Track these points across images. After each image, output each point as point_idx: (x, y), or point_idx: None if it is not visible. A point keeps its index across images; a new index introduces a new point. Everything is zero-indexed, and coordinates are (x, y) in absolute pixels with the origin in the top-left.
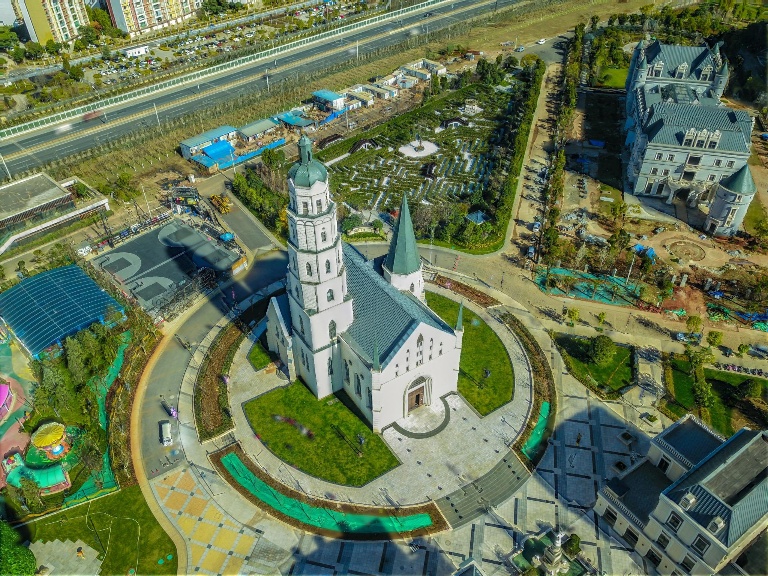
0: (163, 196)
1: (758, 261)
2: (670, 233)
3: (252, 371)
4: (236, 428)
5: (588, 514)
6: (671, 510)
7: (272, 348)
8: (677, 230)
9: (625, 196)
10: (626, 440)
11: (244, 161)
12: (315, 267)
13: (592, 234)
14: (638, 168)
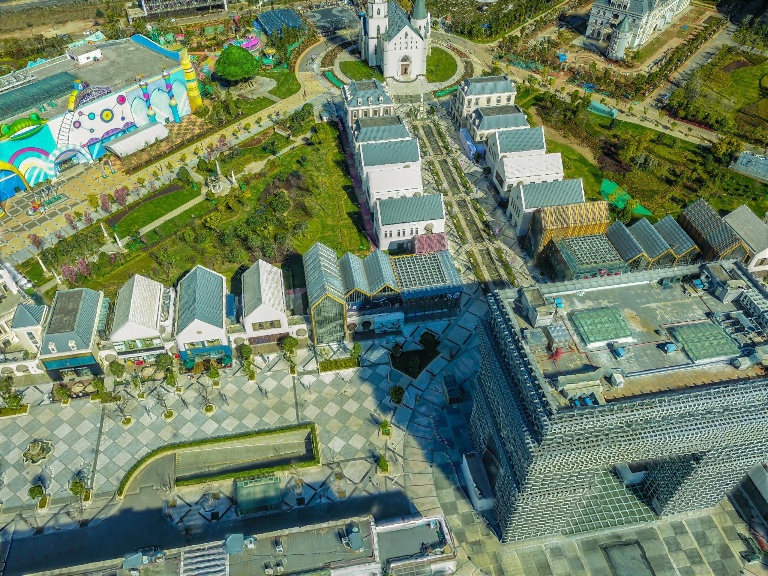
0: None
1: None
2: (586, 54)
3: (349, 55)
4: (334, 67)
5: (446, 111)
6: None
7: (360, 49)
8: (591, 53)
9: (580, 36)
10: None
11: None
12: None
13: None
14: None
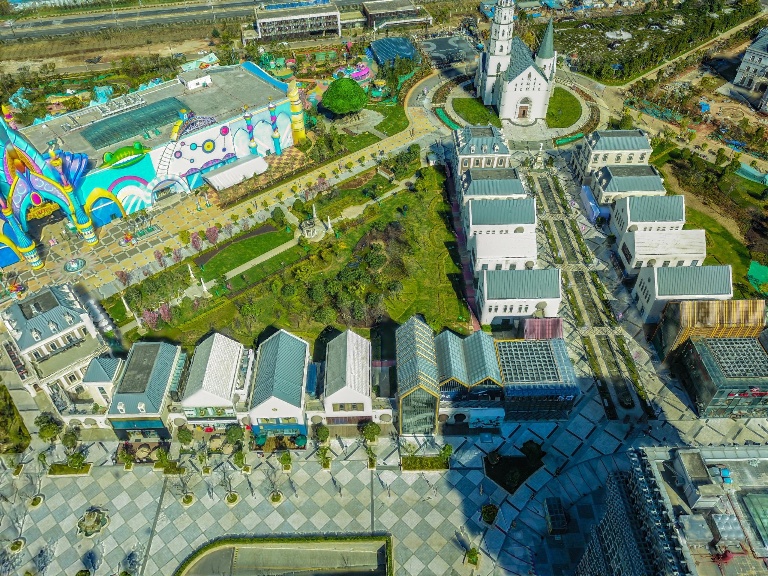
0: None
1: None
2: (733, 104)
3: (463, 91)
4: (446, 103)
5: (566, 162)
6: None
7: (475, 86)
8: (740, 104)
9: (726, 83)
10: None
11: None
12: (498, 31)
13: None
14: None
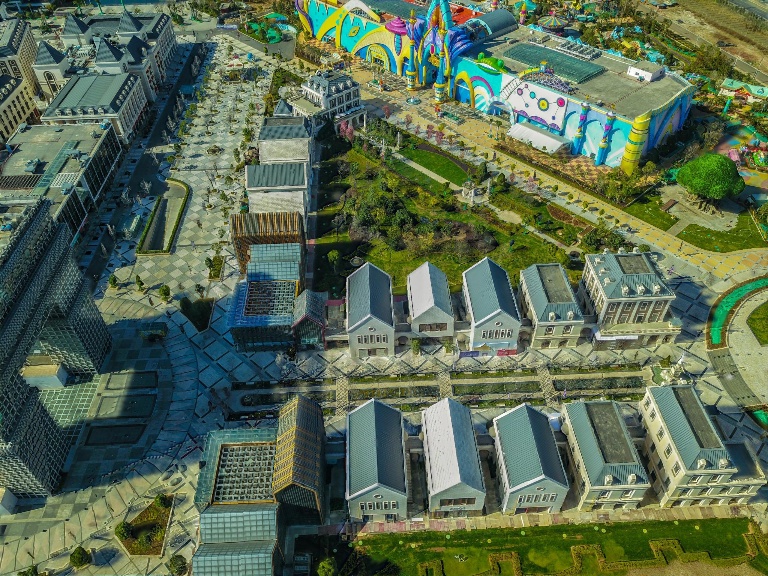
0: None
1: None
2: None
3: None
4: None
5: None
6: None
7: None
8: None
9: None
10: None
11: None
12: None
13: None
14: None
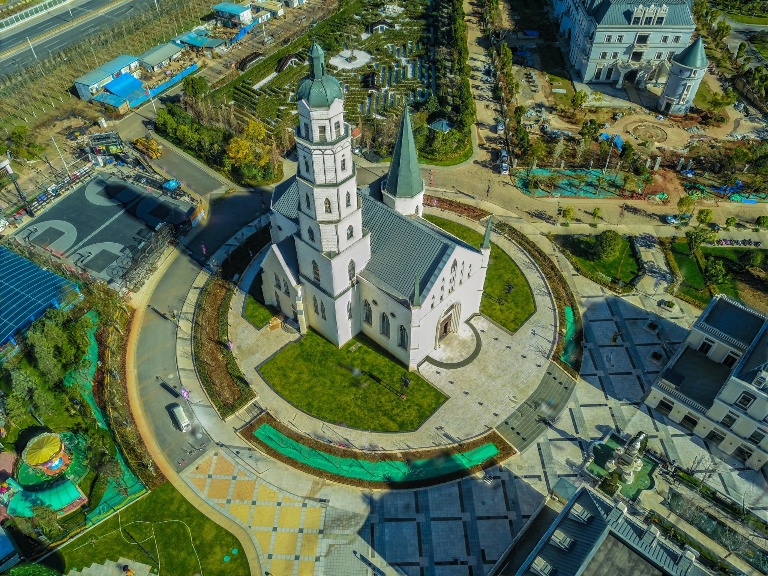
0: (73, 148)
1: (715, 135)
2: (629, 118)
3: (254, 330)
4: (259, 396)
5: (641, 409)
6: (742, 391)
7: (269, 301)
8: (634, 114)
9: (576, 85)
10: (653, 330)
11: (157, 95)
12: (335, 202)
13: (556, 129)
14: (586, 54)
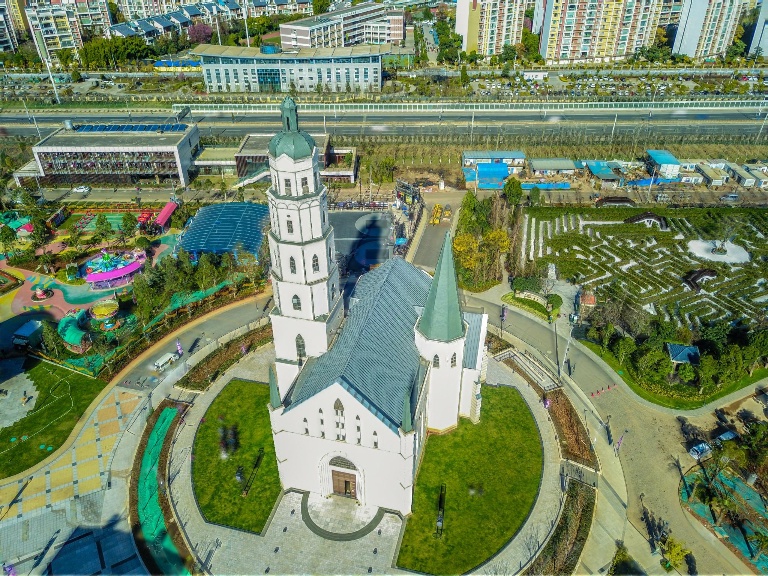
0: None
1: None
2: None
3: None
4: (204, 393)
5: None
6: None
7: None
8: None
9: None
10: None
11: None
12: (278, 259)
13: None
14: None
